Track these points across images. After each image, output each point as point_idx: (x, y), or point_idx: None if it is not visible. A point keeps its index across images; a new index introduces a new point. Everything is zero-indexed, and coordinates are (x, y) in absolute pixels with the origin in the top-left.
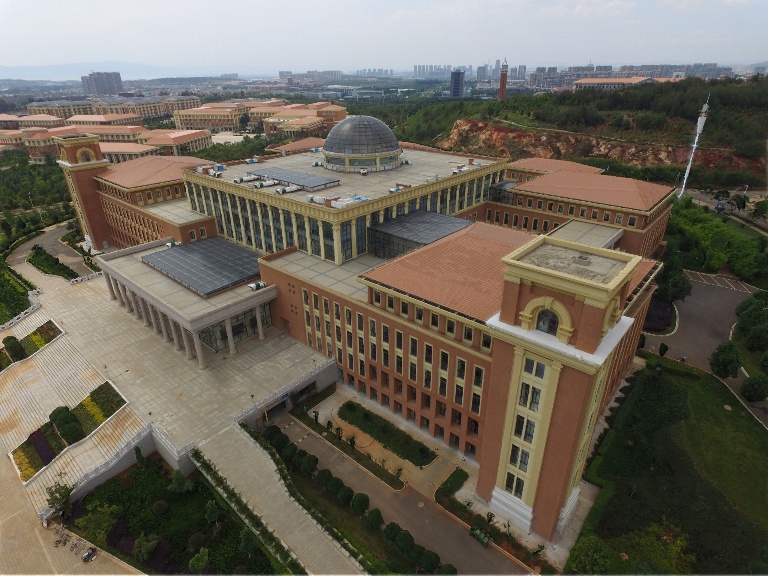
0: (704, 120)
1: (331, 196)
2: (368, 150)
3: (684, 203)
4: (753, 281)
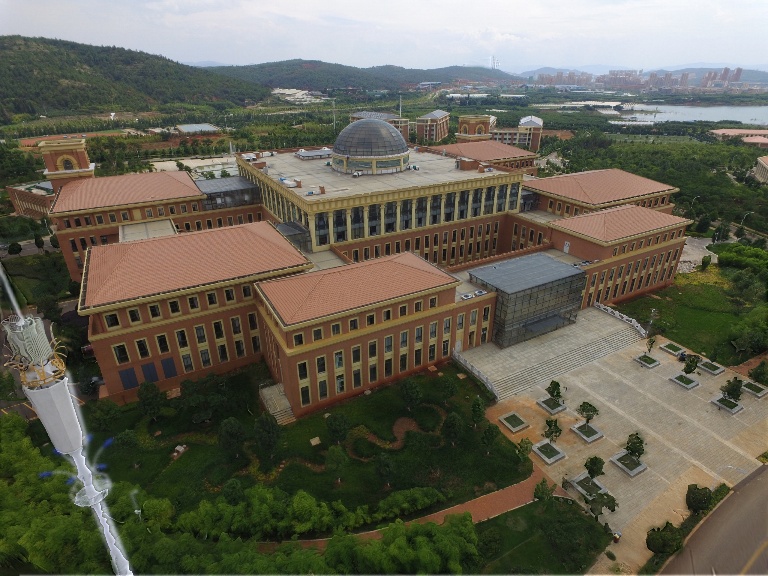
0: None
1: (278, 158)
2: None
3: None
4: None
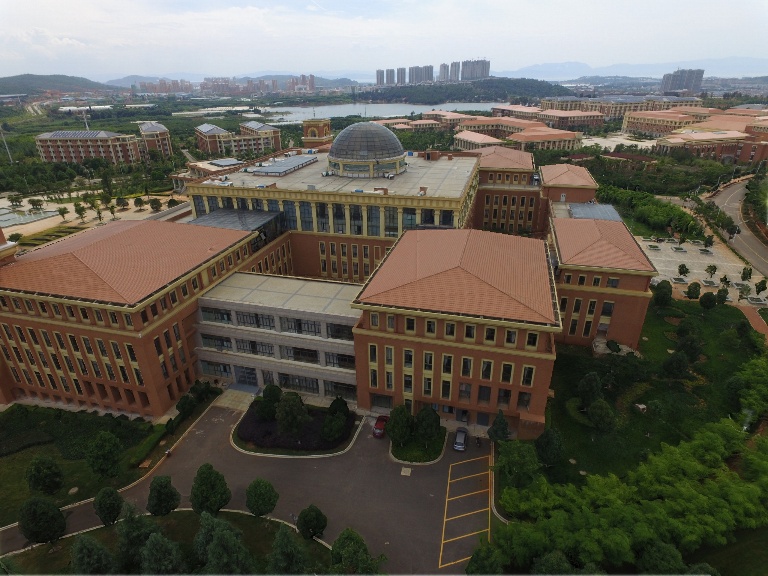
0: None
1: (244, 180)
2: (336, 154)
3: None
4: None
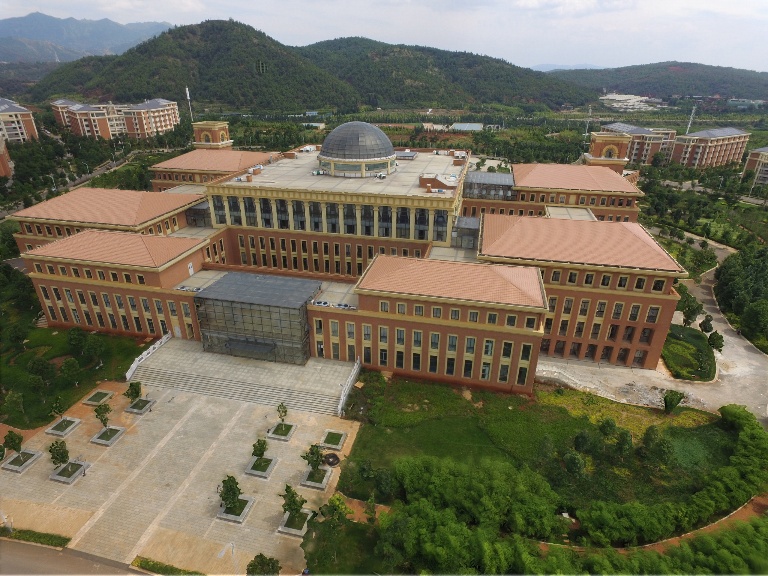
0: None
1: None
2: None
3: None
4: None
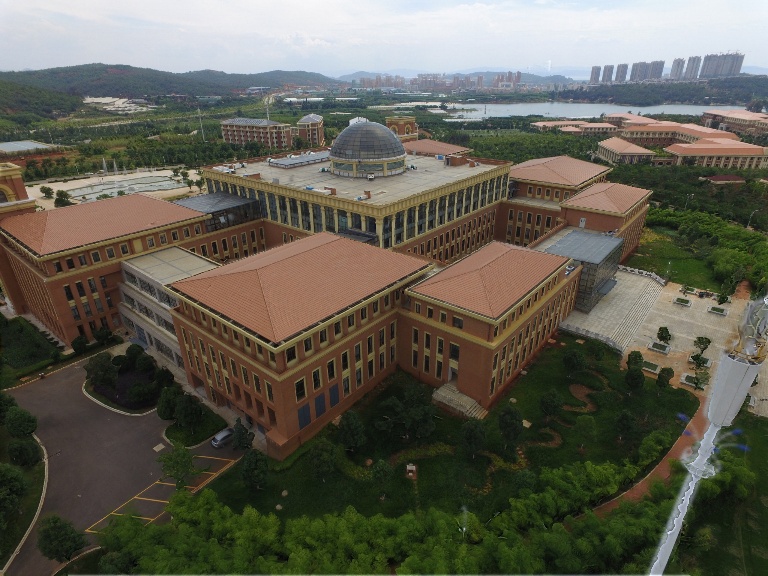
0: (723, 367)
1: (254, 169)
2: None
3: (511, 559)
4: None
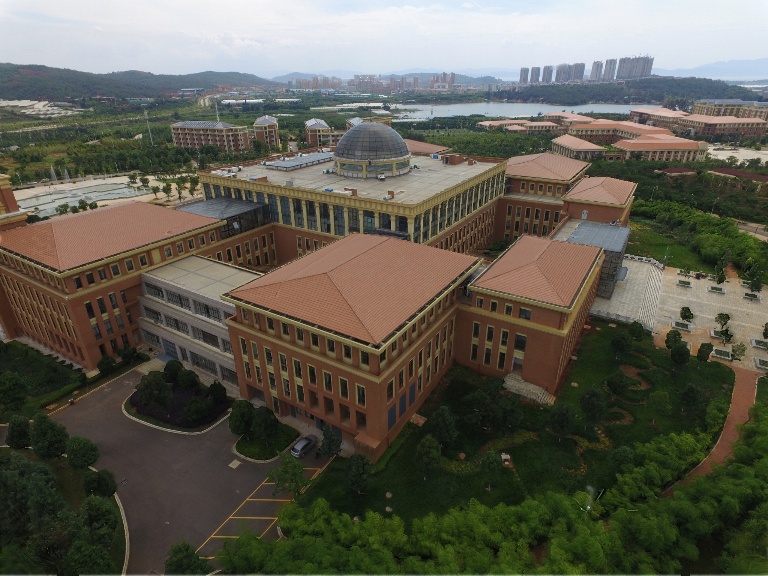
0: None
1: (253, 172)
2: (336, 153)
3: (653, 528)
4: (222, 575)
